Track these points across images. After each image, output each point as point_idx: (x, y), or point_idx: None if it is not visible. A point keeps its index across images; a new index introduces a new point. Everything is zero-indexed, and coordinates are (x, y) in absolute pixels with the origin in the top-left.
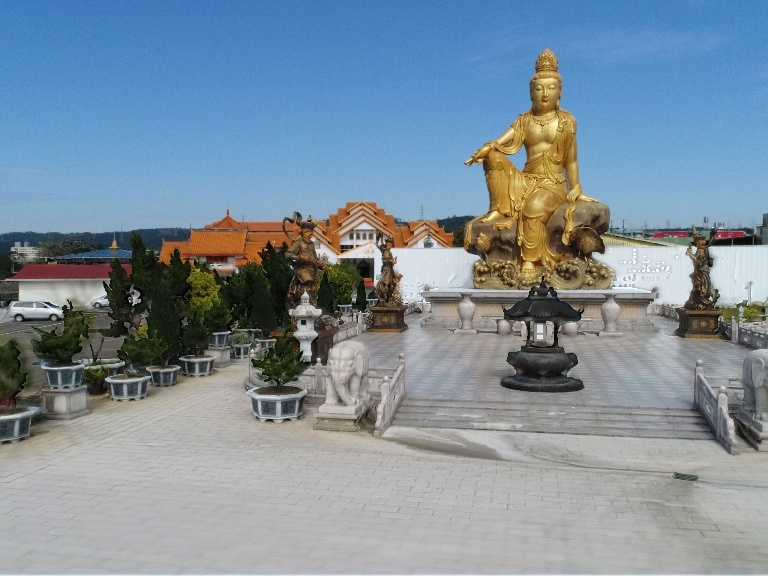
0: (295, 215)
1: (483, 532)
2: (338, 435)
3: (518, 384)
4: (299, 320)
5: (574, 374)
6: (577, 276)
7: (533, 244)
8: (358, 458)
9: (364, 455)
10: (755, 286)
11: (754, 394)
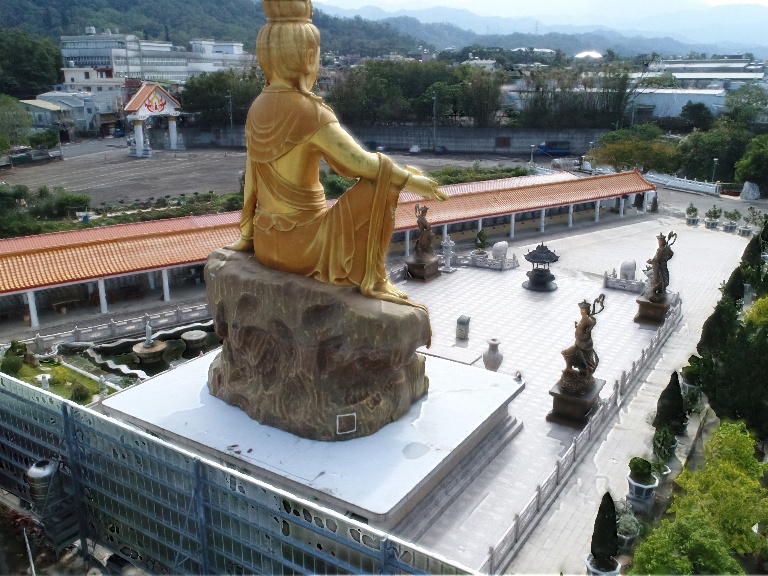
0: None
1: None
2: None
3: None
4: None
5: None
6: None
7: None
8: None
9: None
10: None
11: None
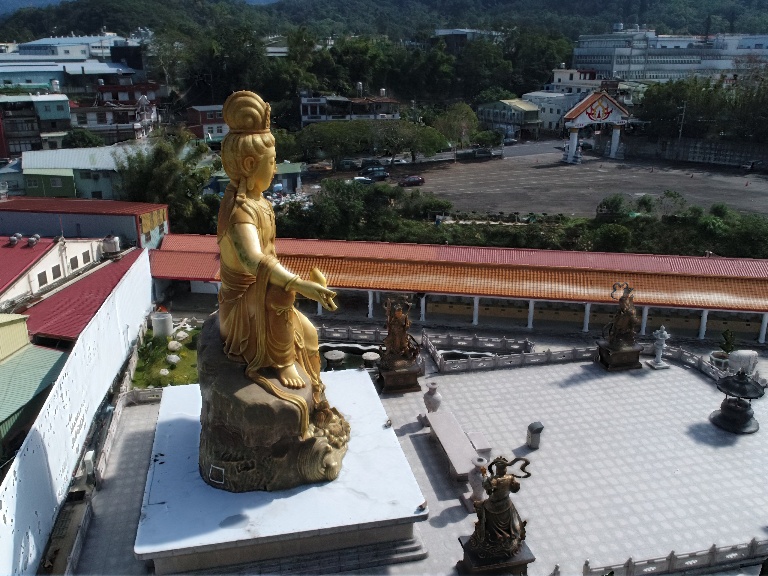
0: None
1: None
2: None
3: None
4: None
5: (684, 417)
6: None
7: None
8: None
9: None
10: None
11: None
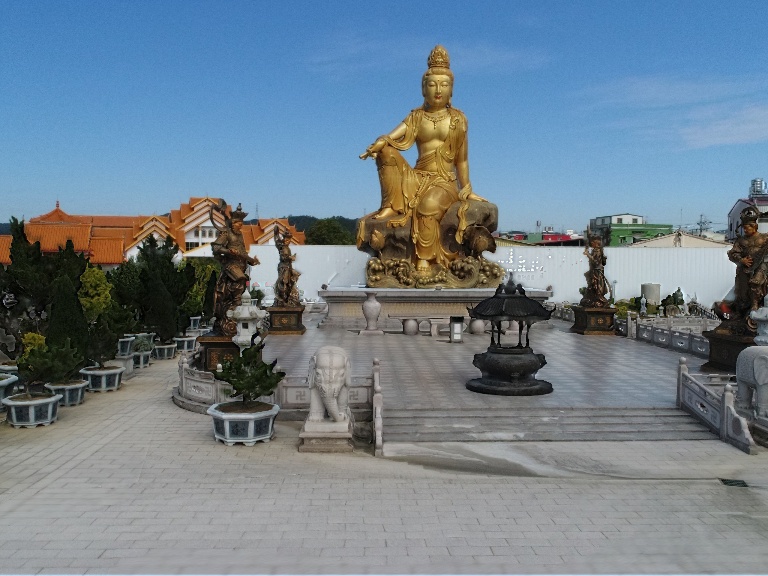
0: (221, 203)
1: (615, 572)
2: (334, 457)
3: (491, 388)
4: (240, 323)
5: None
6: (472, 275)
7: (428, 242)
8: (382, 485)
9: (385, 481)
10: (618, 285)
11: (749, 391)
